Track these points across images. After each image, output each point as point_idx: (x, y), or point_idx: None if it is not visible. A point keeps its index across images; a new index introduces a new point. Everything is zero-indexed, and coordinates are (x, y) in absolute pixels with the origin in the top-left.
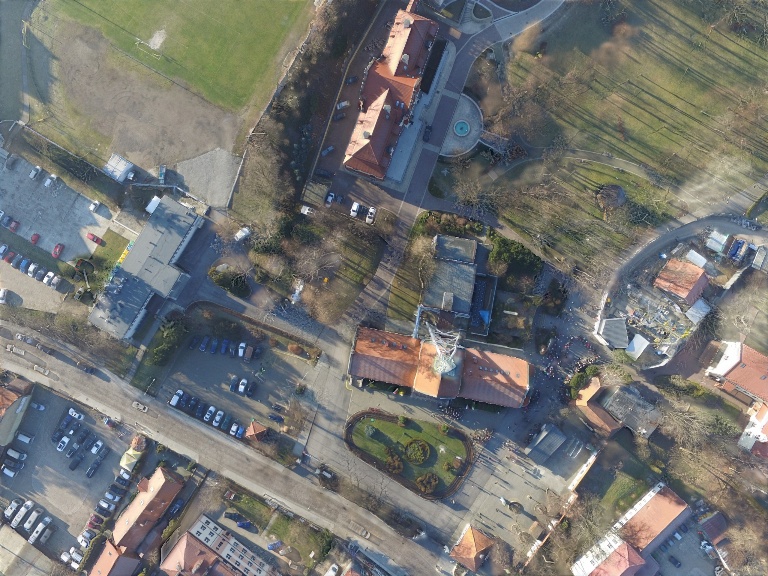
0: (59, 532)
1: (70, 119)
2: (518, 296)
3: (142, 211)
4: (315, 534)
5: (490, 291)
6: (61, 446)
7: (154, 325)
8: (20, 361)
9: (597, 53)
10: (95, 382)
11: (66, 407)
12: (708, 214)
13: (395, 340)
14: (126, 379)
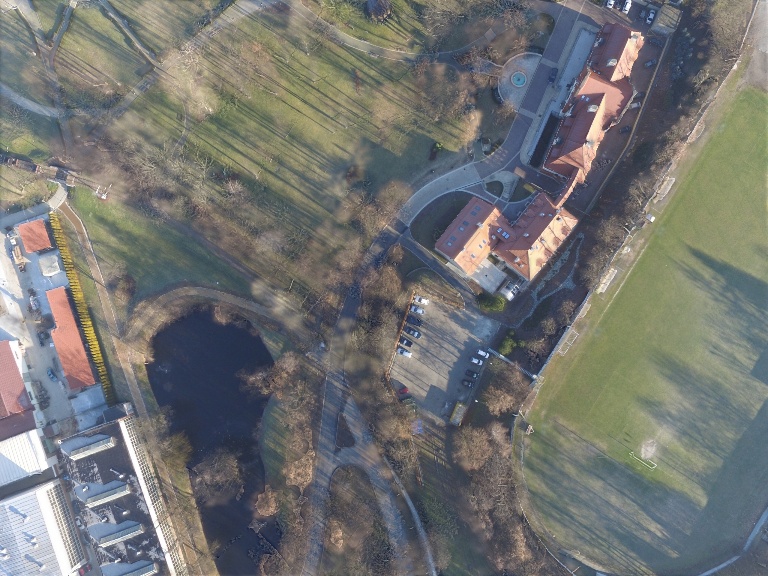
0: None
1: None
2: None
3: None
4: None
5: None
6: None
7: None
8: None
9: (377, 152)
10: None
11: None
12: None
13: None
14: None
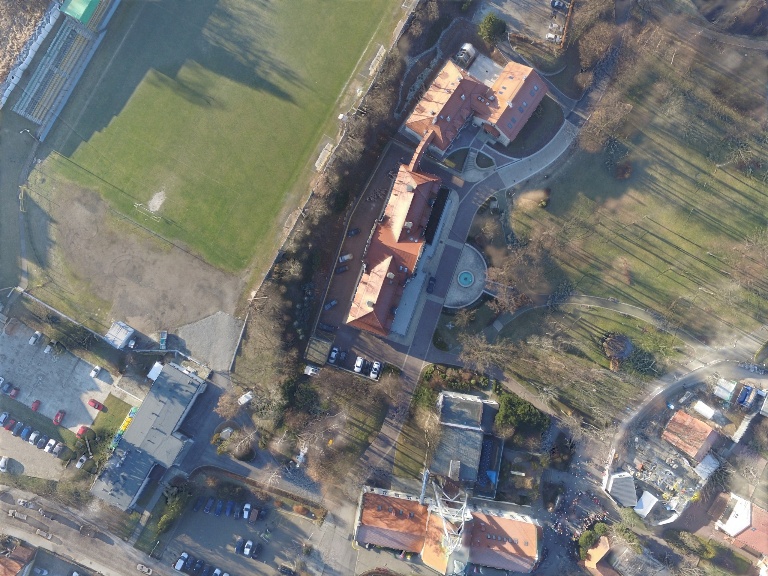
0: None
1: (69, 284)
2: (525, 456)
3: (144, 377)
4: None
5: (497, 448)
6: None
7: (157, 490)
8: (22, 526)
9: (601, 197)
10: (99, 545)
11: (70, 571)
12: (715, 359)
13: (402, 507)
14: (130, 542)
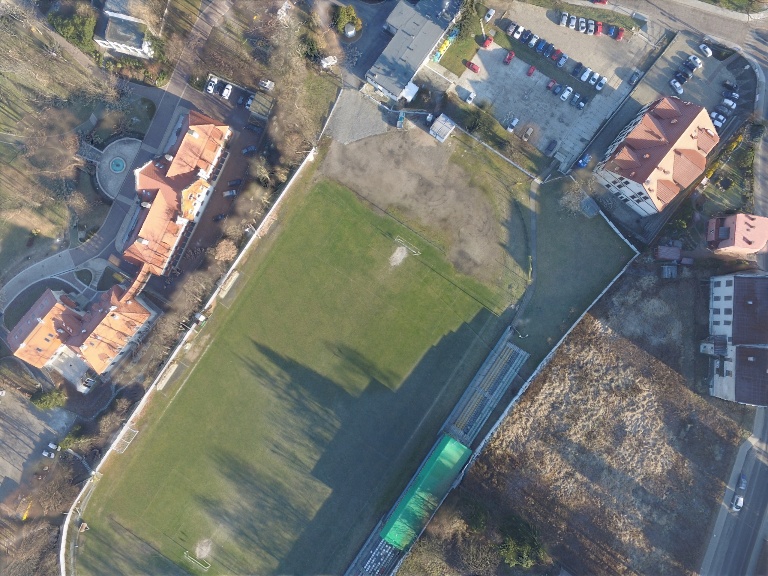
0: None
1: (490, 183)
2: None
3: None
4: None
5: (103, 2)
6: None
7: None
8: None
9: None
10: None
11: None
12: None
13: None
14: None
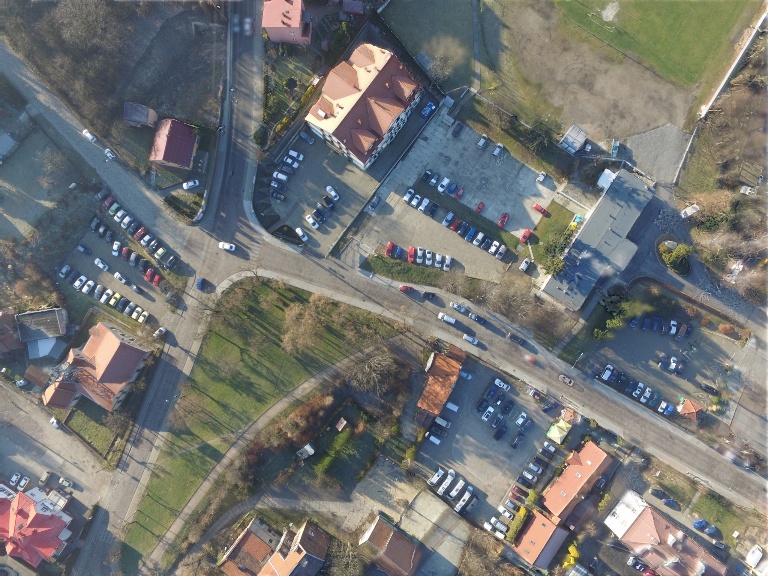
0: (478, 502)
1: (520, 88)
2: None
3: (590, 184)
4: (747, 514)
5: None
6: (488, 416)
7: (594, 299)
8: (450, 329)
9: None
10: (522, 354)
11: (492, 377)
12: None
13: None
14: (554, 352)
